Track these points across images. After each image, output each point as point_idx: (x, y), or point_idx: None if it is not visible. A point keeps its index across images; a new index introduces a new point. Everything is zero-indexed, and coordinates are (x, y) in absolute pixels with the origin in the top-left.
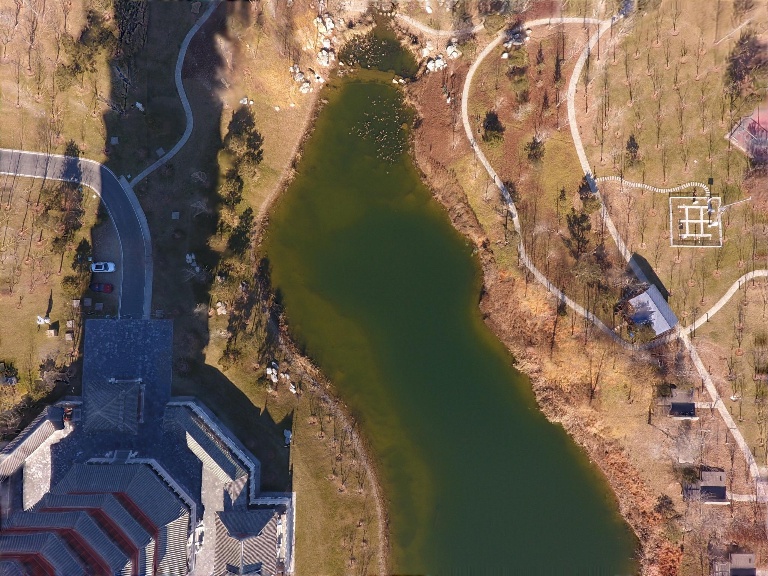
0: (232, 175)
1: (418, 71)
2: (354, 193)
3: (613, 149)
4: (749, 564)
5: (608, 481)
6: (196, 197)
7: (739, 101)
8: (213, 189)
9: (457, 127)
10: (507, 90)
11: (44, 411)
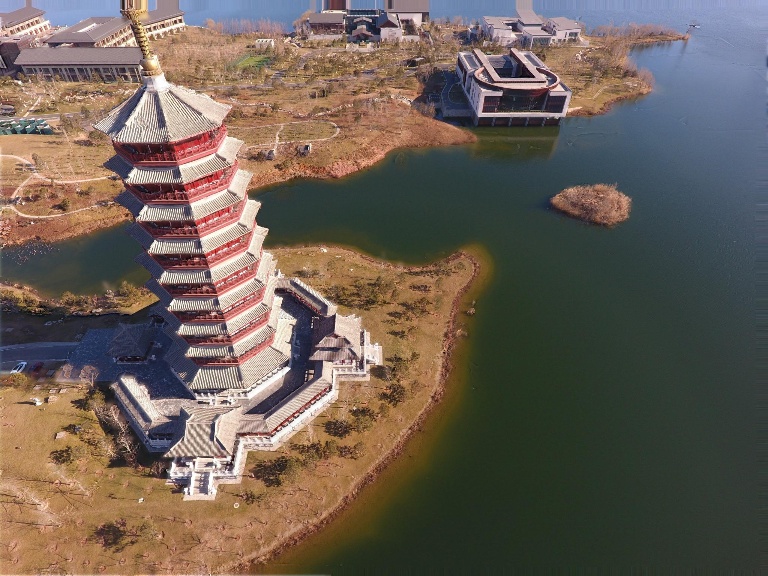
0: (3, 307)
1: (4, 238)
2: (62, 265)
3: (100, 171)
4: (303, 146)
5: (268, 184)
6: (4, 321)
7: (103, 144)
8: (5, 314)
9: (51, 219)
10: (43, 202)
11: (114, 387)
